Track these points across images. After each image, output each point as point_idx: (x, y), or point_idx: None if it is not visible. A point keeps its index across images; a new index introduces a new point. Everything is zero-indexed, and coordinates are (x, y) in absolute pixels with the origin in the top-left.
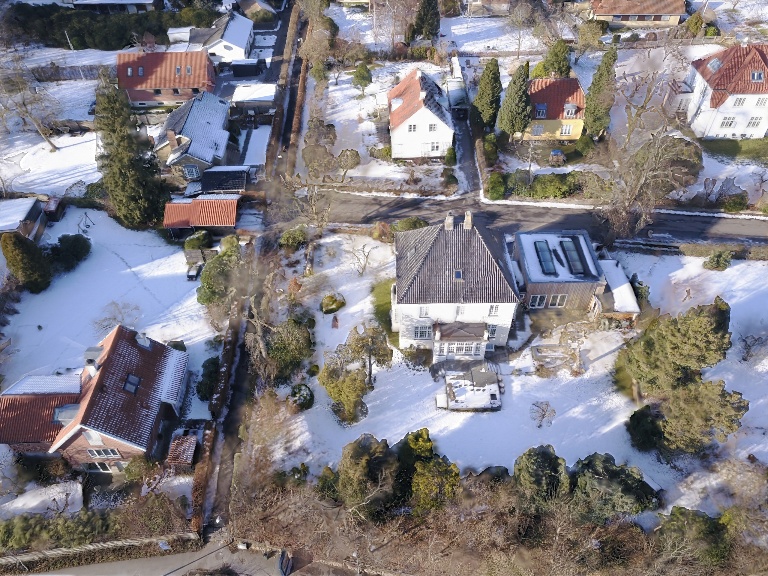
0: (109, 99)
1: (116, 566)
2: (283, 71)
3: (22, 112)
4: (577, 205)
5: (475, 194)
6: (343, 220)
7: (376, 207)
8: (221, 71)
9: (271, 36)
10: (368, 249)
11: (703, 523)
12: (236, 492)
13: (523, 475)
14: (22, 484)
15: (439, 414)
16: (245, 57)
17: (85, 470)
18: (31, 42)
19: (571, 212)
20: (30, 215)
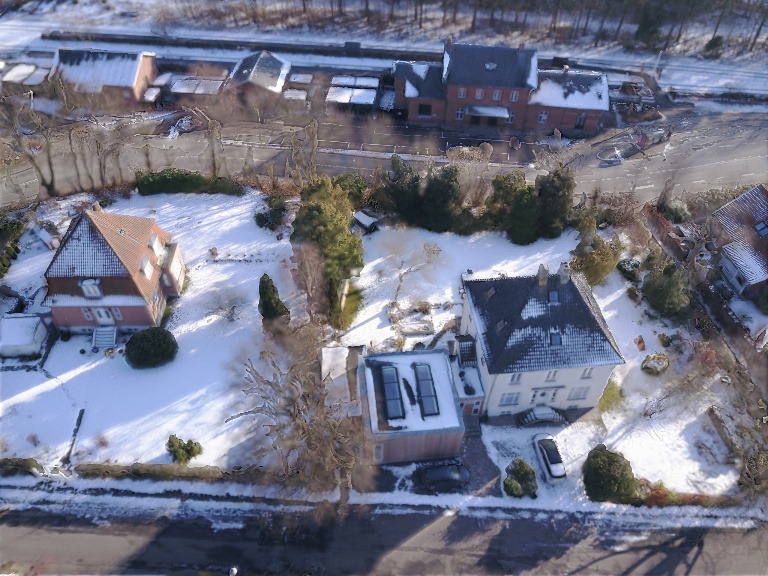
0: None
1: None
2: None
3: None
4: None
5: None
6: (731, 535)
7: (695, 574)
8: None
9: None
10: (659, 461)
11: (341, 185)
12: None
13: (458, 167)
14: None
15: None
16: None
17: None
18: None
19: None
20: None
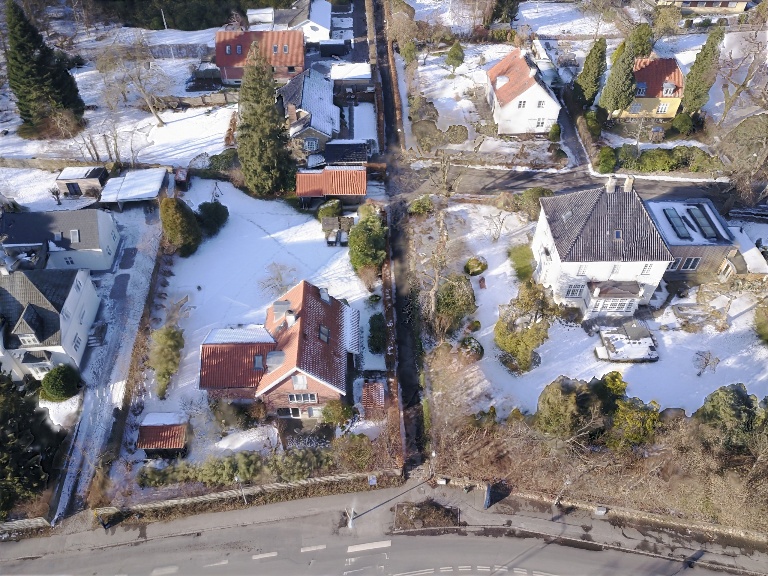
0: (258, 70)
1: (327, 500)
2: (372, 51)
3: (136, 87)
4: (683, 178)
5: (584, 168)
6: (463, 191)
7: (492, 179)
8: (308, 51)
9: (347, 18)
10: None
11: None
12: (430, 433)
13: (723, 409)
14: (222, 428)
15: (600, 365)
16: (329, 38)
17: (277, 416)
18: (110, 22)
19: (679, 185)
20: (164, 184)
